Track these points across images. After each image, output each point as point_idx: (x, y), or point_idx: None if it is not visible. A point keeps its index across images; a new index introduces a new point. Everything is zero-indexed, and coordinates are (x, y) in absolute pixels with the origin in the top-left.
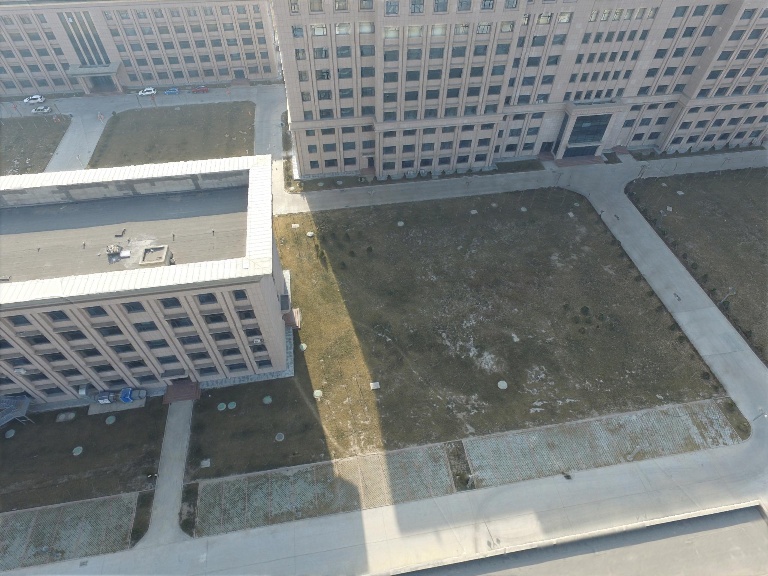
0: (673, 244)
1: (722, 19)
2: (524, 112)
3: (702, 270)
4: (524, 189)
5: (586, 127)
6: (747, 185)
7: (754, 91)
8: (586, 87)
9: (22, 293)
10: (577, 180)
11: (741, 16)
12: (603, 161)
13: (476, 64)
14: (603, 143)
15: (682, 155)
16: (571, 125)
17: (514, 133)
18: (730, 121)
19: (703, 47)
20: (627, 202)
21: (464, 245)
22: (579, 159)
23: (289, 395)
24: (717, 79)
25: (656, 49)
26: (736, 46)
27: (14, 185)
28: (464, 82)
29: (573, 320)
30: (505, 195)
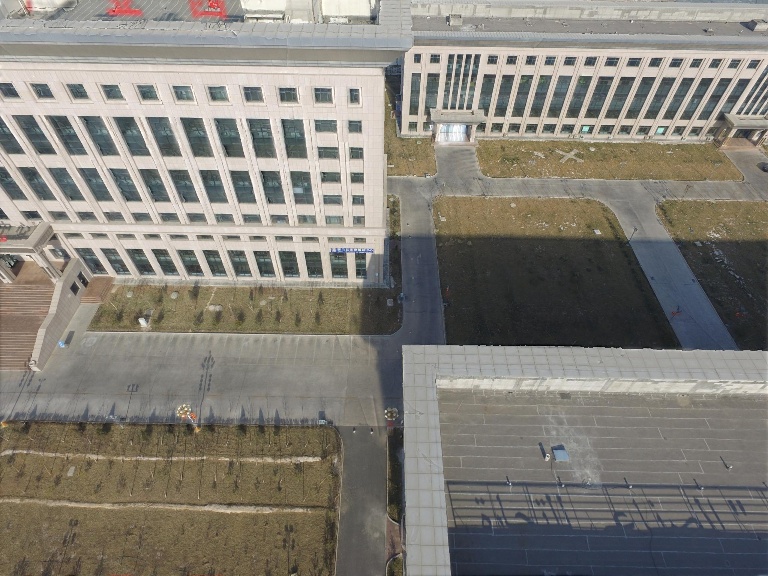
0: None
1: None
2: None
3: None
4: None
5: None
6: None
7: None
8: None
9: (504, 1)
10: None
11: None
12: None
13: None
14: None
15: None
16: None
17: None
18: None
19: None
20: None
21: None
22: None
23: (399, 91)
24: None
25: None
26: None
27: (556, 34)
28: None
29: None
30: None
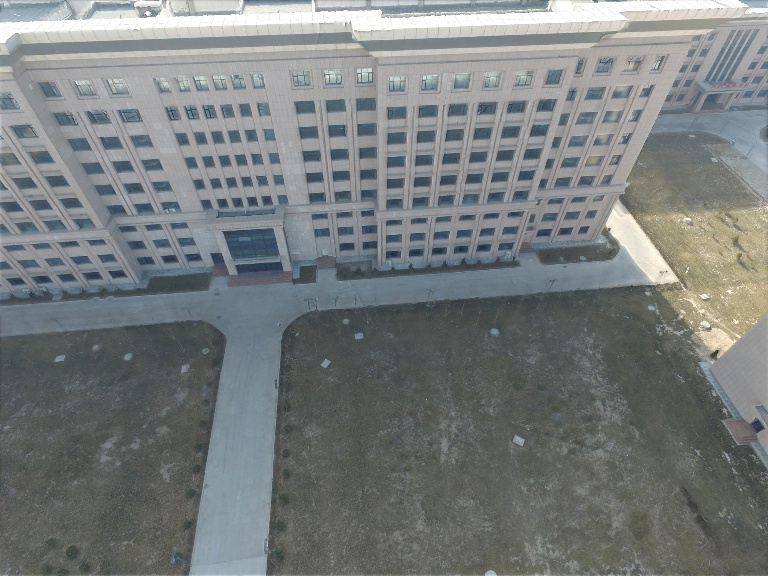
0: (285, 429)
1: (376, 116)
2: (153, 223)
3: (295, 481)
4: (156, 322)
5: (247, 241)
6: (457, 327)
7: (473, 200)
8: (227, 194)
9: None
10: (236, 309)
11: (389, 115)
12: (291, 279)
13: (14, 175)
14: (284, 258)
15: (401, 273)
16: (221, 240)
17: (165, 243)
18: (459, 233)
19: (373, 148)
20: (275, 350)
21: (2, 416)
22: (259, 276)
23: None
24: (403, 188)
25: (300, 151)
26: (405, 151)
27: None
28: (15, 195)
29: (39, 572)
30: (122, 331)
